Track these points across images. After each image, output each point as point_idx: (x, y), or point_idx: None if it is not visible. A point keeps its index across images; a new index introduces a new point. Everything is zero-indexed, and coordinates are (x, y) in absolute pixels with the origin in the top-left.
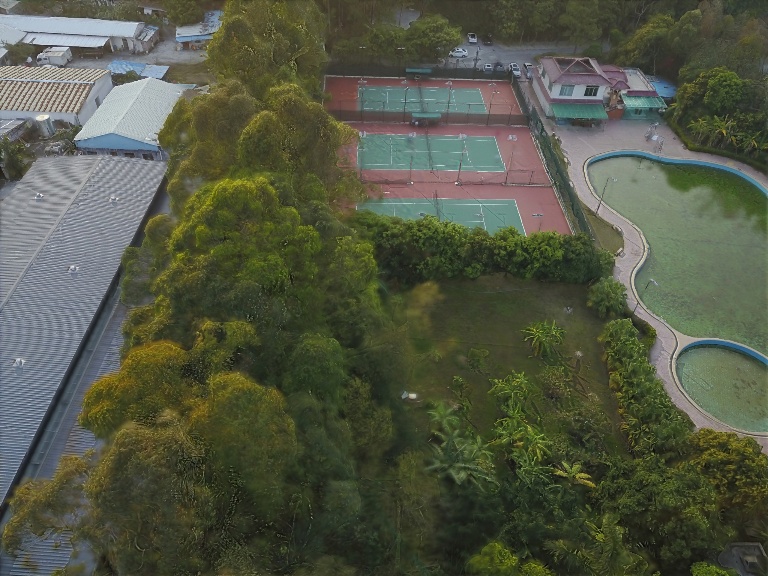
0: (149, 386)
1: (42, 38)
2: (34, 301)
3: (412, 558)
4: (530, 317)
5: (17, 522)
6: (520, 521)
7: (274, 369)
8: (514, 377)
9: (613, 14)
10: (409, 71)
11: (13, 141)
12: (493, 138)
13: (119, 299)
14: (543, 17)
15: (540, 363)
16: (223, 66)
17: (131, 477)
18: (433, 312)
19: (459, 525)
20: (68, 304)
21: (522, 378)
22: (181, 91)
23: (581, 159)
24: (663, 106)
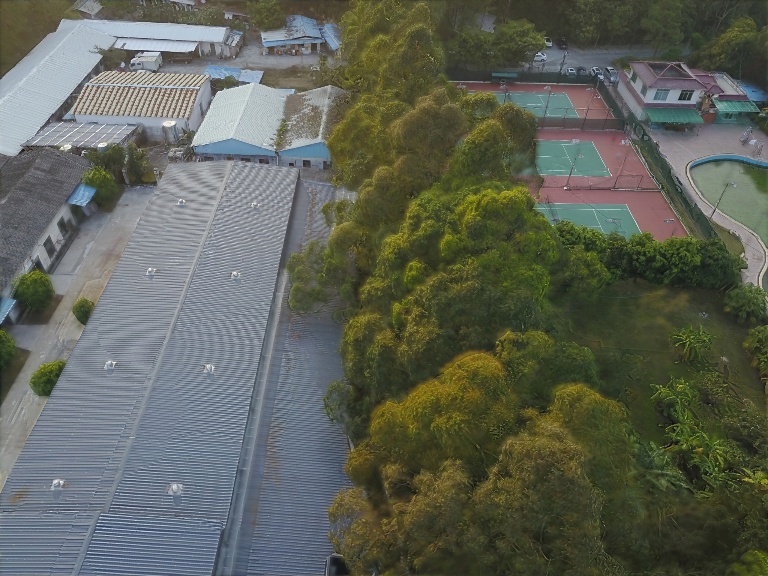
0: (489, 396)
1: (132, 43)
2: (207, 307)
3: (675, 565)
4: (668, 322)
5: (360, 530)
6: (754, 528)
7: (532, 377)
8: (677, 383)
9: (690, 18)
10: (495, 75)
11: None
12: (591, 142)
13: (281, 305)
14: (622, 21)
15: (688, 368)
16: (402, 74)
17: (555, 488)
18: (571, 317)
19: (684, 532)
20: (240, 310)
21: (683, 384)
22: (285, 96)
23: (682, 163)
24: (756, 110)
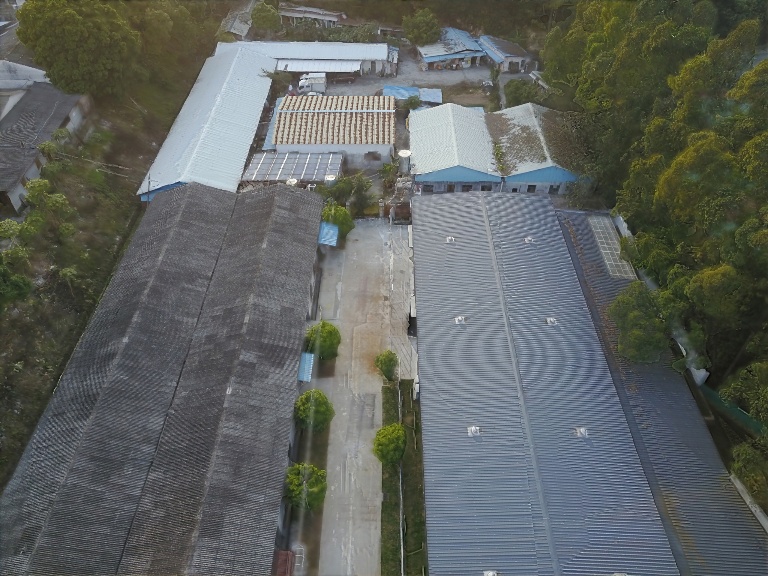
0: None
1: (294, 64)
2: (542, 360)
3: None
4: None
5: None
6: None
7: None
8: None
9: None
10: None
11: (340, 176)
12: None
13: None
14: None
15: None
16: (767, 101)
17: None
18: None
19: None
20: (576, 362)
21: None
22: (482, 116)
23: None
24: None
